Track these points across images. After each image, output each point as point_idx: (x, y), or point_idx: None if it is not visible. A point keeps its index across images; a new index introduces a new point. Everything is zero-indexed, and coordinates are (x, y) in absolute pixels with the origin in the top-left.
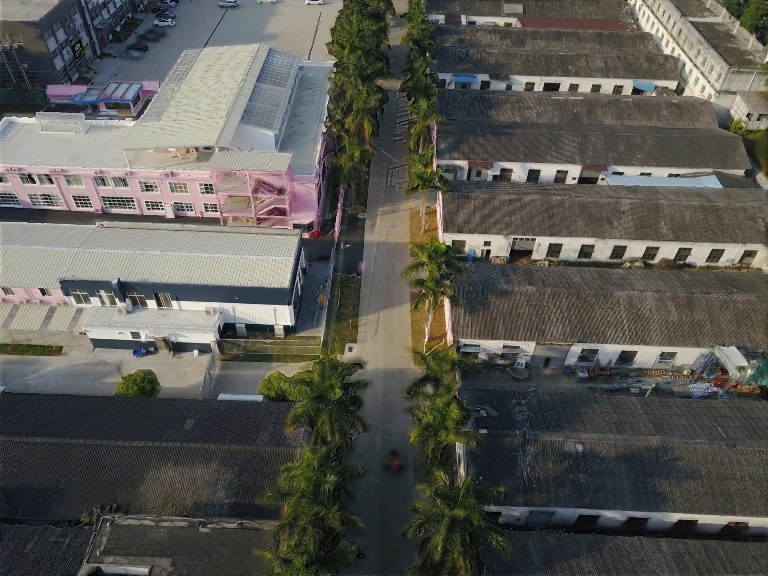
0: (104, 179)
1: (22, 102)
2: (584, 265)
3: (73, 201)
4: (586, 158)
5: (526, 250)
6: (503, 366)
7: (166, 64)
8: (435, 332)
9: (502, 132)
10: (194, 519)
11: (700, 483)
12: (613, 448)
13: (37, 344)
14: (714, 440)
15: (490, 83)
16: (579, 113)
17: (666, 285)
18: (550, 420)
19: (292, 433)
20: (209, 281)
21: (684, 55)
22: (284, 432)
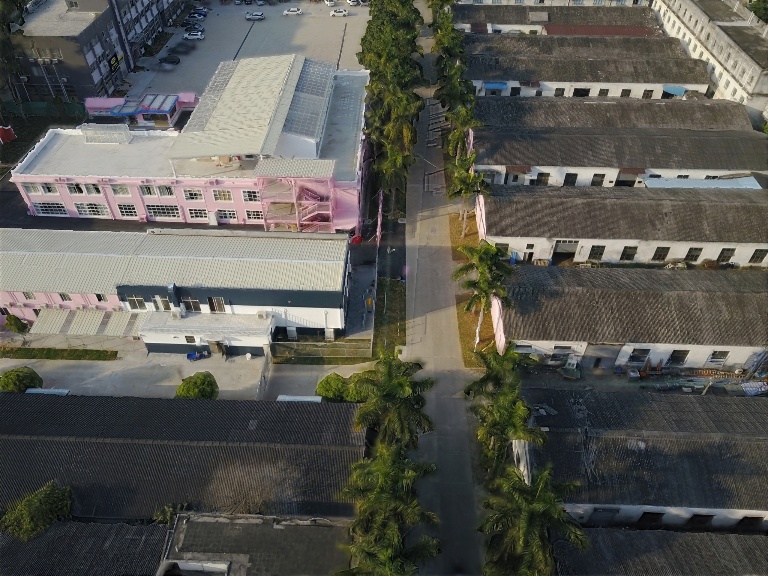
0: (150, 188)
1: (62, 115)
2: (626, 267)
3: (119, 210)
4: (623, 161)
5: (568, 252)
6: (553, 367)
7: (198, 76)
8: (483, 334)
9: (538, 137)
10: (268, 516)
11: (765, 480)
12: (676, 445)
13: (93, 349)
14: None
15: (520, 90)
16: (612, 117)
17: (715, 285)
18: (610, 418)
19: (355, 433)
20: (262, 285)
21: (713, 59)
22: (347, 432)
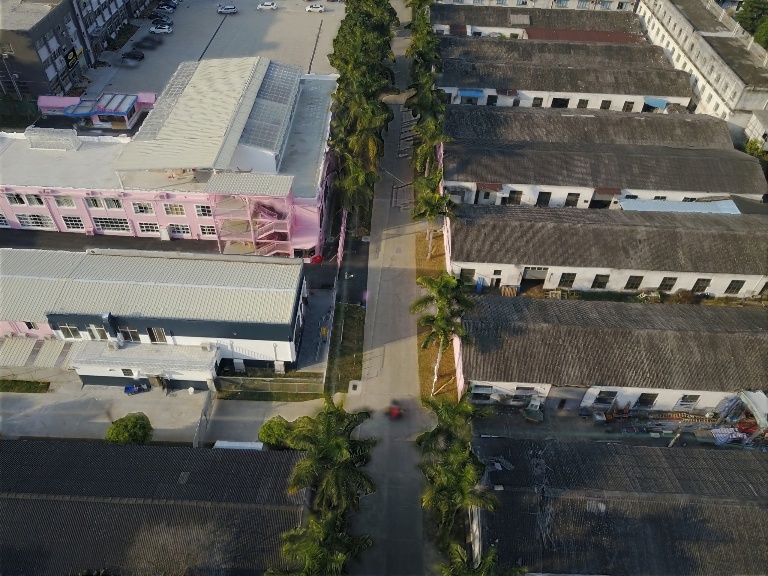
0: (96, 200)
1: (12, 114)
2: (598, 295)
3: (63, 222)
4: (599, 181)
5: (538, 279)
6: (516, 407)
7: (162, 73)
8: (444, 369)
9: (511, 152)
10: None
11: (731, 547)
12: (638, 508)
13: (23, 380)
14: (745, 499)
15: (497, 98)
16: (590, 132)
17: (687, 322)
18: (570, 475)
19: None
20: (206, 315)
21: (696, 71)
22: (285, 487)
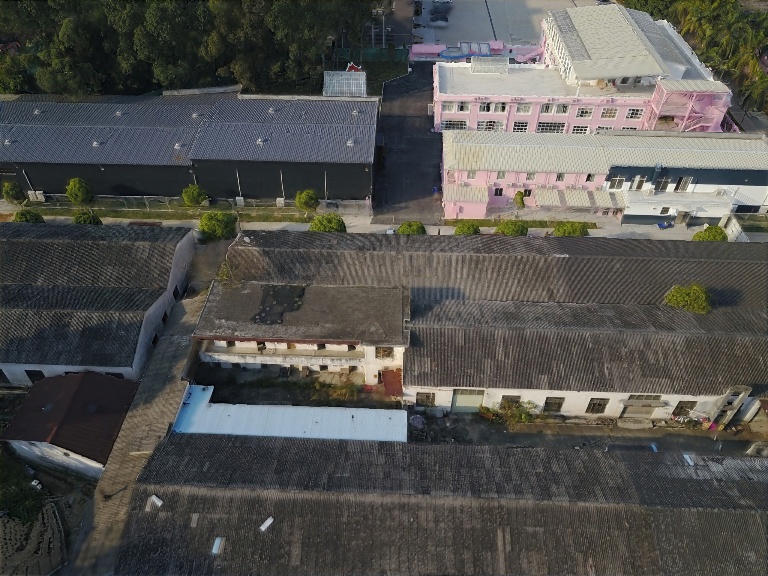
0: (549, 106)
1: (391, 59)
2: None
3: (513, 127)
4: None
5: None
6: None
7: (472, 32)
8: None
9: None
10: None
11: None
12: None
13: None
14: None
15: None
16: None
17: None
18: None
19: None
20: (722, 168)
21: None
22: None
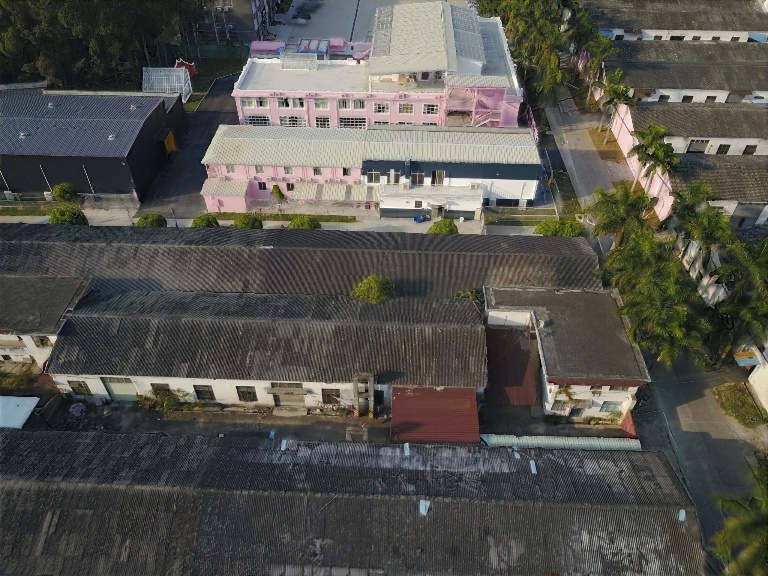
0: (346, 102)
1: (231, 56)
2: None
3: (315, 122)
4: (733, 85)
5: (699, 151)
6: None
7: (330, 29)
8: None
9: (659, 66)
10: (548, 288)
11: None
12: None
13: (335, 215)
14: None
15: (623, 37)
16: (714, 55)
17: None
18: None
19: (585, 249)
20: (475, 162)
21: None
22: (578, 249)
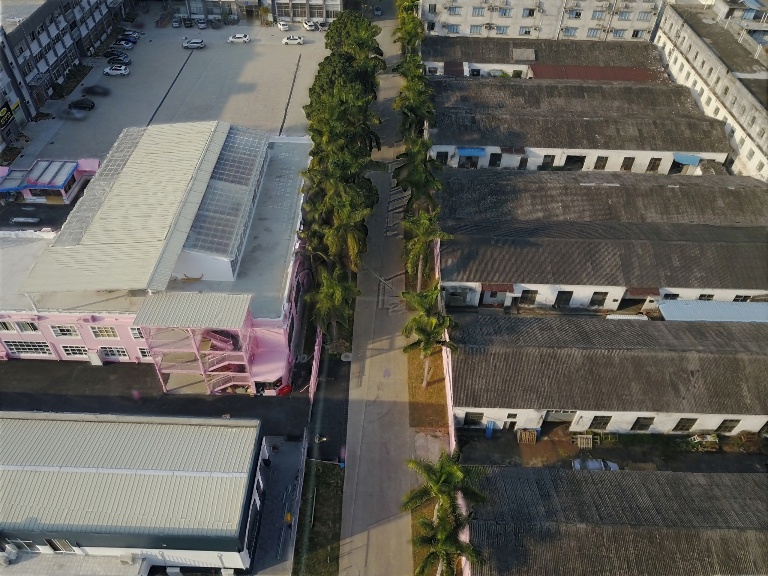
0: (5, 323)
1: None
2: (639, 439)
3: None
4: (632, 278)
5: (563, 421)
6: None
7: (114, 127)
8: None
9: (523, 241)
10: None
11: None
12: None
13: None
14: None
15: (501, 156)
16: (615, 205)
17: None
18: None
19: None
20: (125, 520)
21: (733, 120)
22: None
